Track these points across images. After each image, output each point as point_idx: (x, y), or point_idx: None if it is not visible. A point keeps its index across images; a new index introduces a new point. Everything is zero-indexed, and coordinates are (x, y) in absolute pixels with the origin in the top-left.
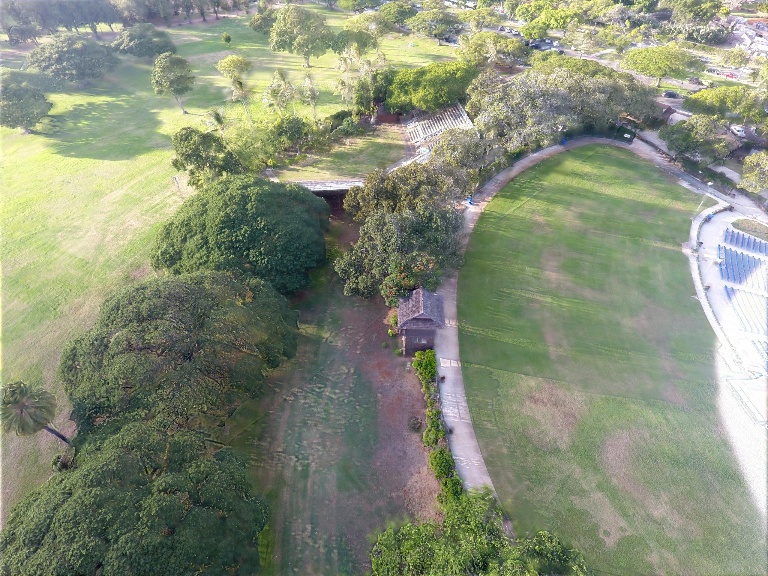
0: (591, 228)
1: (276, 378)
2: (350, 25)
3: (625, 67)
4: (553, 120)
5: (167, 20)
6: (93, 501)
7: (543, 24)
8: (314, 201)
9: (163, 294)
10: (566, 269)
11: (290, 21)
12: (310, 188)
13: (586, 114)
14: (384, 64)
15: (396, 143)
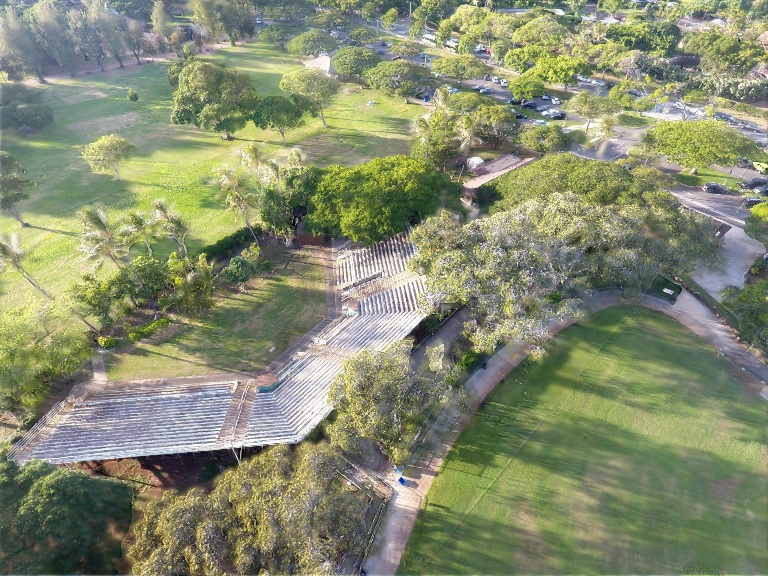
0: (625, 546)
1: None
2: (287, 83)
3: (651, 150)
4: (552, 309)
5: (70, 68)
6: None
7: (539, 77)
8: (79, 526)
9: None
10: None
11: (194, 85)
12: (106, 456)
13: (607, 278)
14: (330, 134)
15: (315, 288)
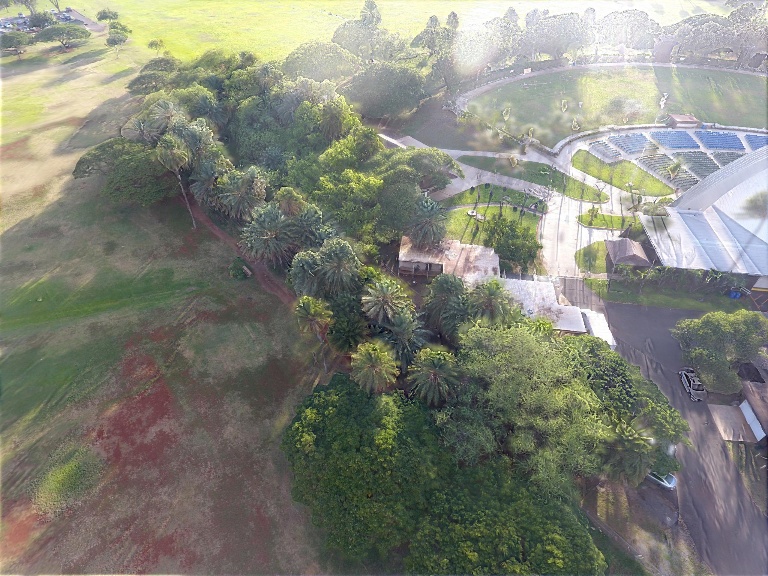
0: None
1: None
2: None
3: None
4: None
5: None
6: None
7: None
8: None
9: (637, 11)
10: (748, 95)
11: None
12: None
13: None
14: None
15: None
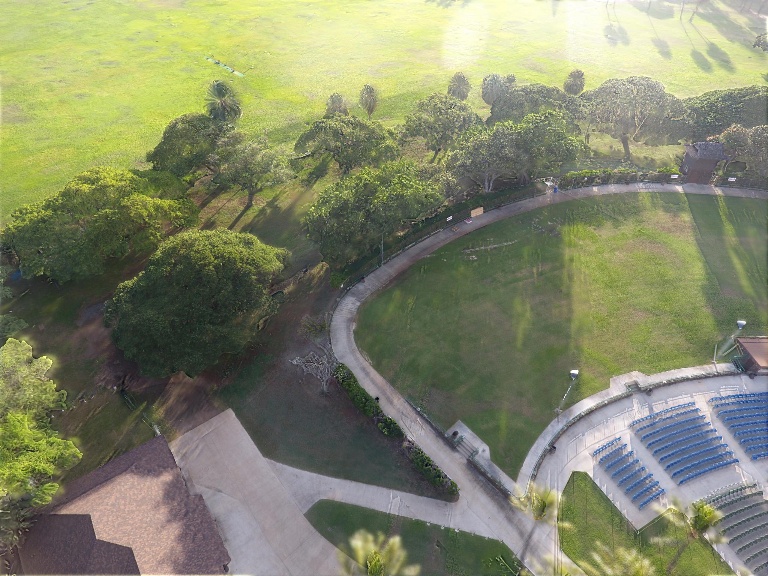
0: None
1: (633, 157)
2: None
3: None
4: None
5: None
6: (547, 88)
7: None
8: None
9: (649, 82)
10: None
11: None
12: None
13: None
14: None
15: None
